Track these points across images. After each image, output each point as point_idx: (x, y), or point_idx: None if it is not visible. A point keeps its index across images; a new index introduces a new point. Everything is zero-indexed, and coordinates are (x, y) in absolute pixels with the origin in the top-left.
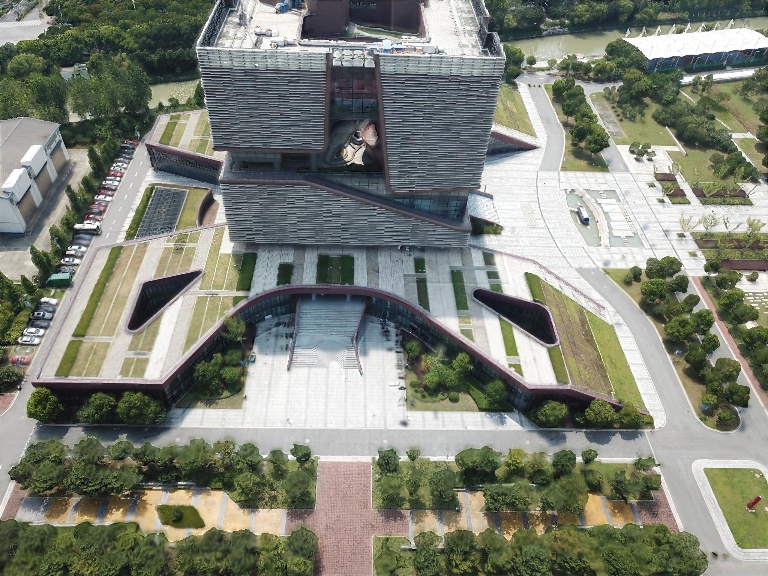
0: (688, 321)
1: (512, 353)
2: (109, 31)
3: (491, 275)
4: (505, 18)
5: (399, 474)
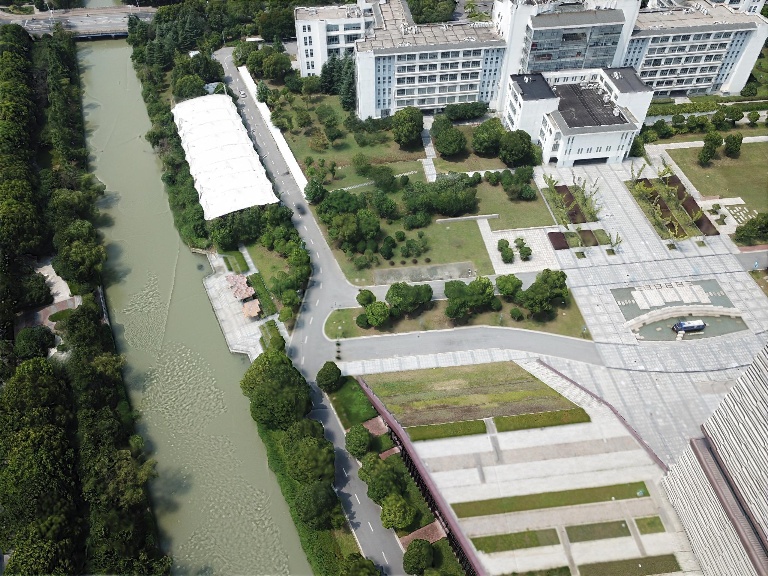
0: None
1: None
2: None
3: None
4: (101, 371)
5: None
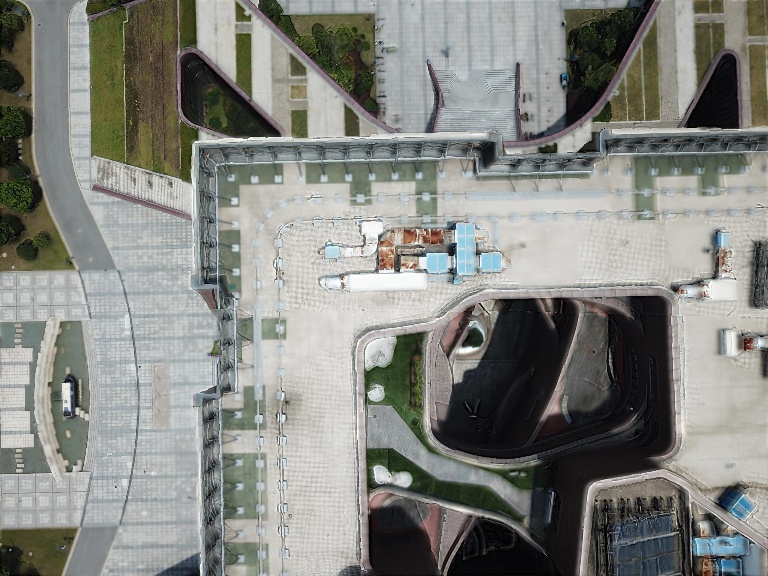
0: None
1: (244, 38)
2: None
3: None
4: None
5: None
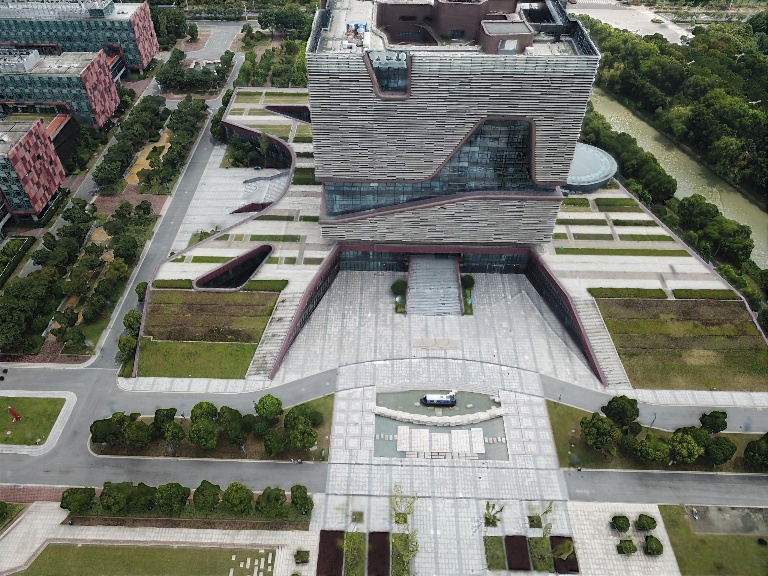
0: (200, 409)
1: (195, 259)
2: (645, 47)
3: (290, 259)
4: None
5: (144, 225)
